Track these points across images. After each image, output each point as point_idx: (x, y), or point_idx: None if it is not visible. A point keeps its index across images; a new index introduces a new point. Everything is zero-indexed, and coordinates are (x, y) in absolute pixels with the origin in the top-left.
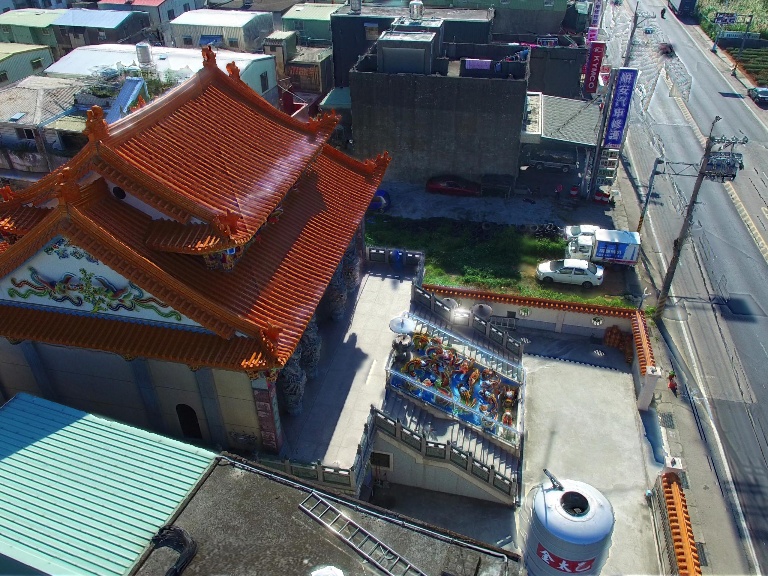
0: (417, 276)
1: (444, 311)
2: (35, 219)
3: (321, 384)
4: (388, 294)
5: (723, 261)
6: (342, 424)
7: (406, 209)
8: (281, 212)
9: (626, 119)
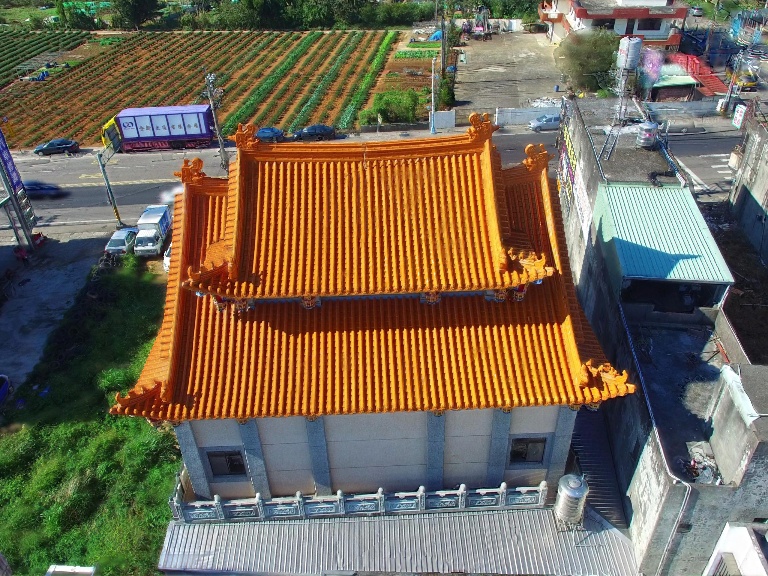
0: None
1: None
2: (517, 245)
3: None
4: None
5: (163, 196)
6: None
7: (9, 372)
8: None
9: (12, 158)
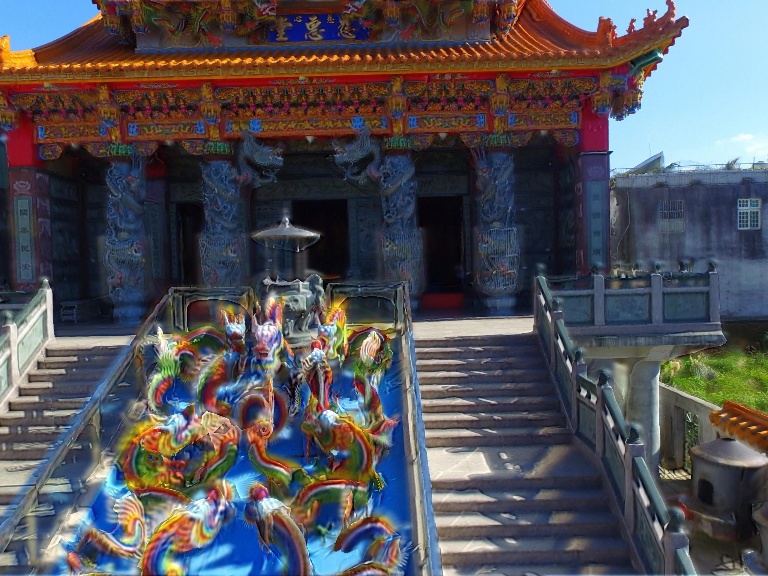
0: (590, 281)
1: (567, 375)
2: None
3: (196, 325)
4: (533, 324)
5: None
6: (73, 337)
7: None
8: (269, 17)
9: None
